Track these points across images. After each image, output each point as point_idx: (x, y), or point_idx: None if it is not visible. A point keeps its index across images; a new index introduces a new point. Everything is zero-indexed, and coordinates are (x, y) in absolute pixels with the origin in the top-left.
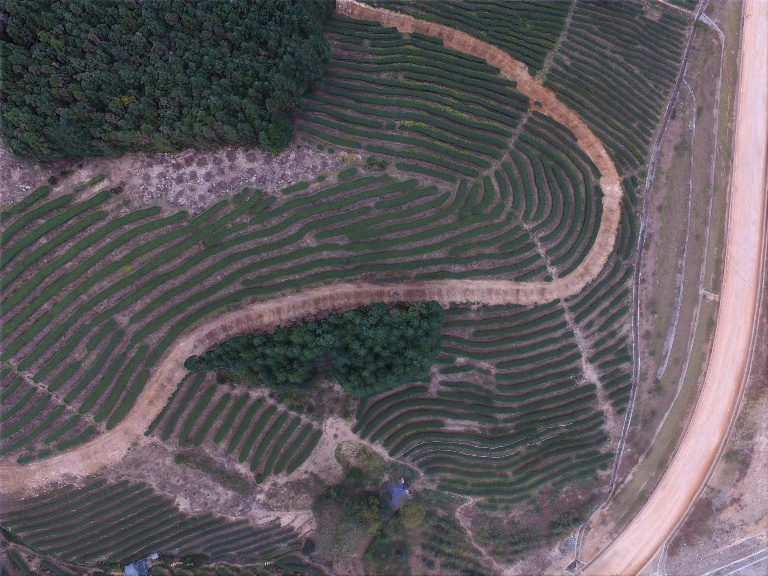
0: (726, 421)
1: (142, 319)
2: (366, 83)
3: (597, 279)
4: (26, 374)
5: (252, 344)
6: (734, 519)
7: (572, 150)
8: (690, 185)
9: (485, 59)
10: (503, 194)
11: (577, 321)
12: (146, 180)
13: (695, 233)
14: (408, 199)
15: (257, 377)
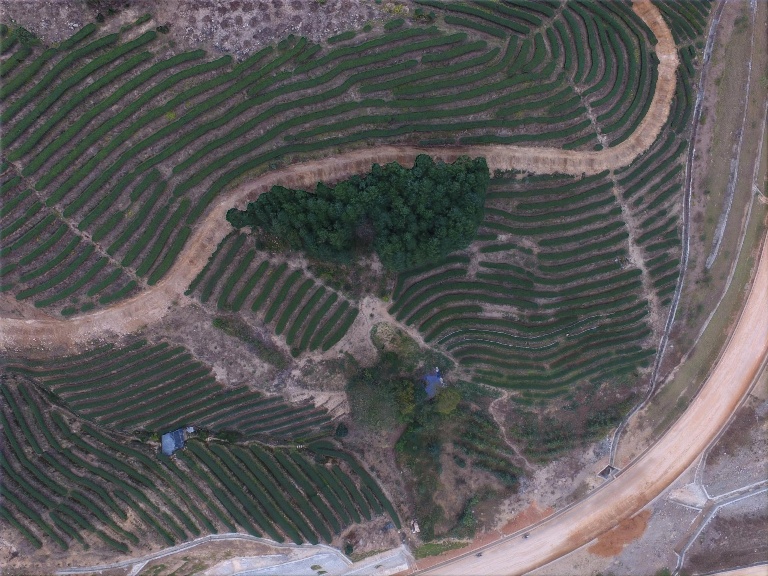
0: None
1: (185, 171)
2: None
3: (649, 152)
4: (71, 222)
5: (294, 199)
6: None
7: (627, 14)
8: (749, 66)
9: None
10: (555, 52)
11: (626, 195)
12: (192, 23)
13: (751, 120)
14: (456, 53)
15: (298, 234)
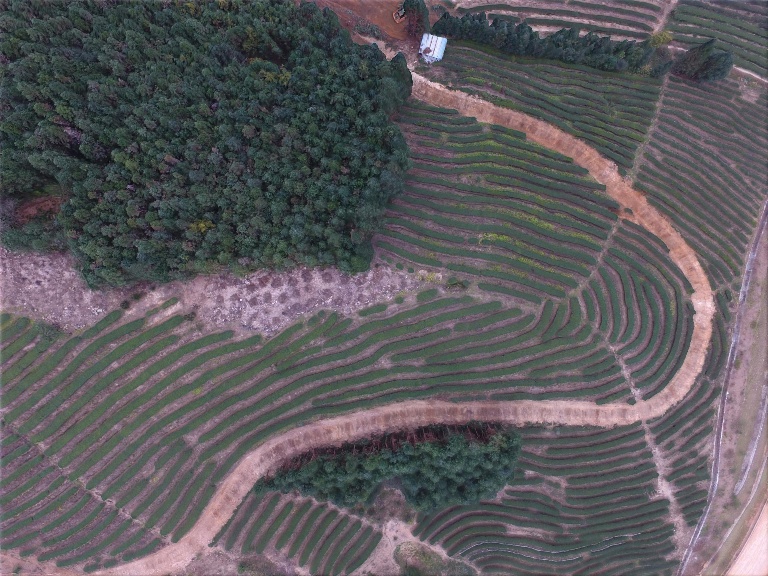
0: None
1: (210, 438)
2: (446, 188)
3: (682, 400)
4: (94, 490)
5: (322, 468)
6: None
7: (664, 263)
8: None
9: (571, 156)
10: (590, 316)
11: (658, 442)
12: (220, 303)
13: None
14: (490, 322)
15: (326, 499)
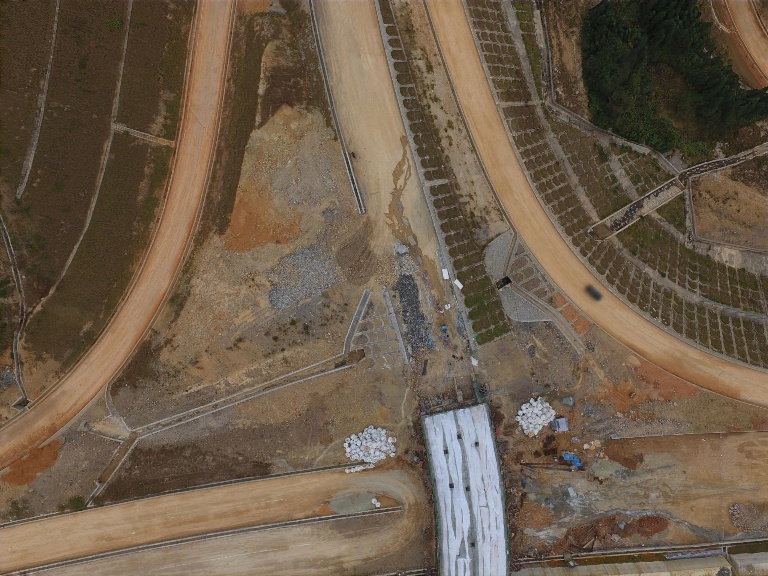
0: (176, 266)
1: None
2: None
3: None
4: None
5: None
6: (172, 361)
7: None
8: (57, 6)
9: None
10: None
11: None
12: None
13: (78, 59)
14: None
15: None
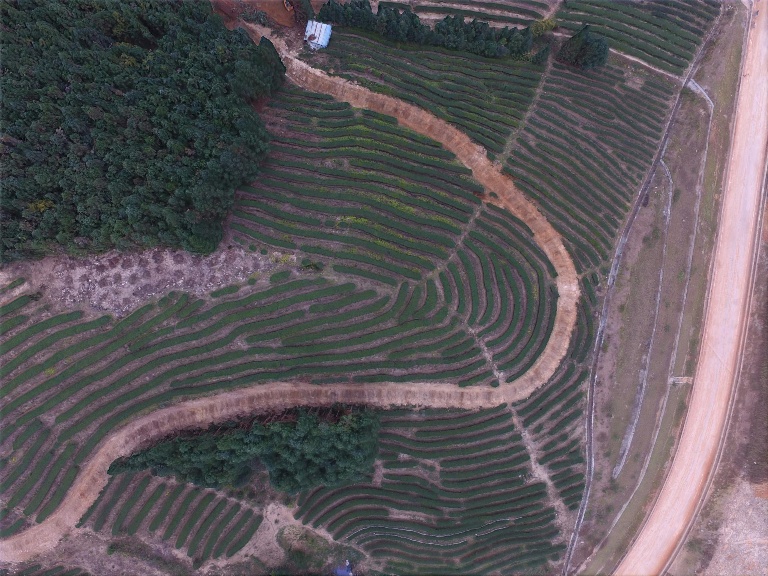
0: (692, 508)
1: (69, 418)
2: (309, 171)
3: (548, 383)
4: None
5: None
6: None
7: (527, 247)
8: (660, 275)
9: (441, 140)
10: (447, 298)
11: (525, 425)
12: (68, 283)
13: (664, 324)
14: (344, 304)
15: (185, 479)
